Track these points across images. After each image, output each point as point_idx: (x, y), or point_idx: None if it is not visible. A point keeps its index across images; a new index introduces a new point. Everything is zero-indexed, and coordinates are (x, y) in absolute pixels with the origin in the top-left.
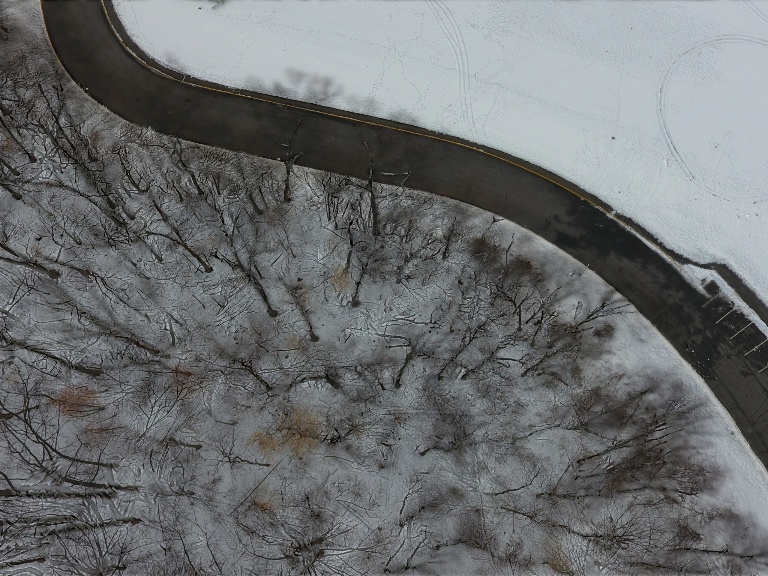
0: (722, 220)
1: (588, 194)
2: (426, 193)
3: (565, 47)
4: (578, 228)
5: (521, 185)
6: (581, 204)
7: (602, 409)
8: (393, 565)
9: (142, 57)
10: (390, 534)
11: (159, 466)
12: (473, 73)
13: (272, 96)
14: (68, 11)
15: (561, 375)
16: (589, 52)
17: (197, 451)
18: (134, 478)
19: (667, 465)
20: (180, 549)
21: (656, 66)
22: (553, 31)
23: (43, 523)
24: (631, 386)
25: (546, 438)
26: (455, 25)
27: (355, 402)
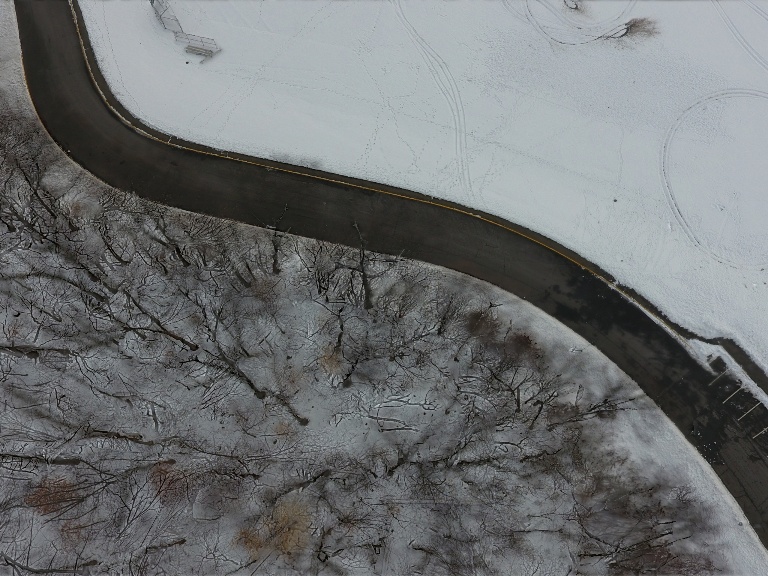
0: (729, 291)
1: (589, 263)
2: (421, 262)
3: (565, 103)
4: (579, 299)
5: (520, 253)
6: (582, 274)
7: (604, 506)
8: None
9: (126, 117)
10: None
11: (139, 572)
12: (470, 131)
13: (261, 159)
14: (50, 67)
15: (561, 460)
16: (590, 108)
17: (180, 546)
18: None
19: (672, 557)
20: None
21: (659, 123)
22: (553, 85)
23: None
24: (634, 471)
25: (546, 529)
26: (451, 80)
27: (346, 491)
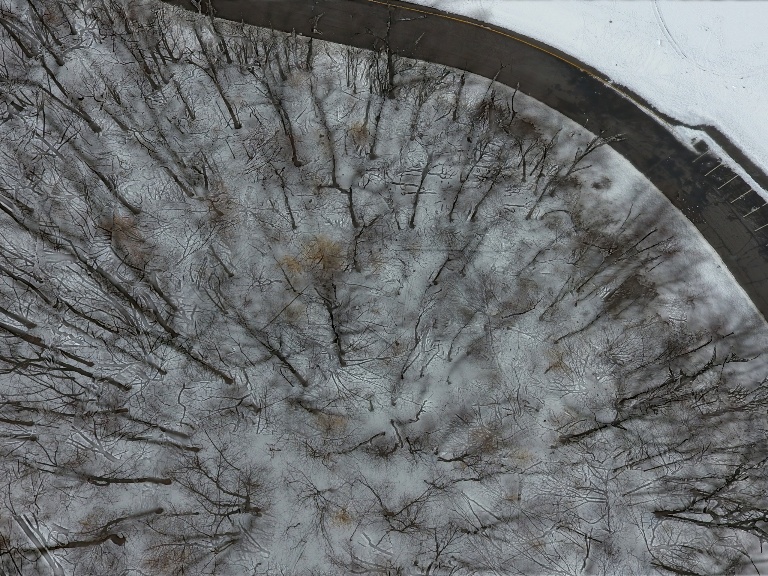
0: (711, 89)
1: (587, 66)
2: (437, 64)
3: None
4: (578, 96)
5: (525, 58)
6: (581, 75)
7: None
8: (409, 373)
9: None
10: (406, 348)
11: (198, 276)
12: None
13: None
14: None
15: (562, 219)
16: None
17: (229, 278)
18: (175, 289)
19: (659, 296)
20: (216, 357)
21: None
22: None
23: (95, 321)
24: (626, 230)
25: (548, 272)
26: None
27: (373, 239)
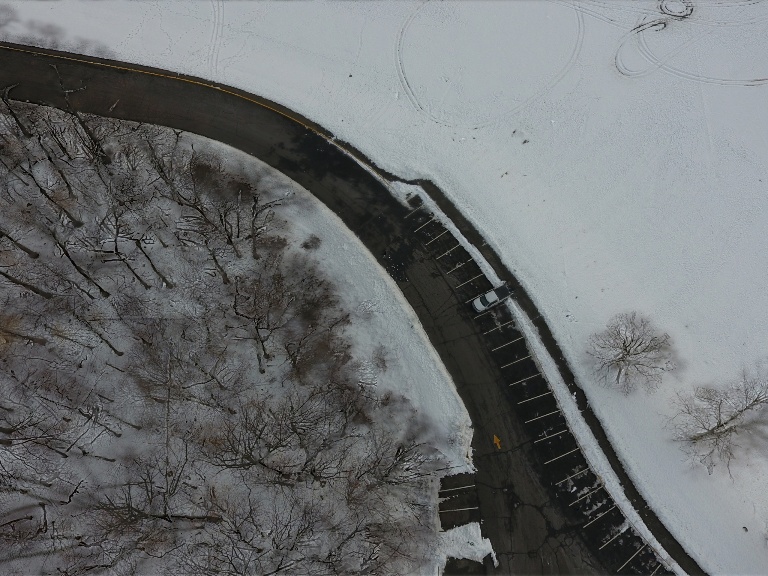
0: (434, 142)
1: (312, 123)
2: (161, 127)
3: None
4: (300, 153)
5: (252, 117)
6: (305, 132)
7: None
8: (73, 451)
9: None
10: (76, 424)
11: None
12: (227, 23)
13: (29, 46)
14: None
15: (262, 282)
16: (339, 2)
17: None
18: None
19: (353, 359)
20: None
21: (400, 12)
22: None
23: None
24: (330, 291)
25: (241, 338)
26: None
27: (63, 310)
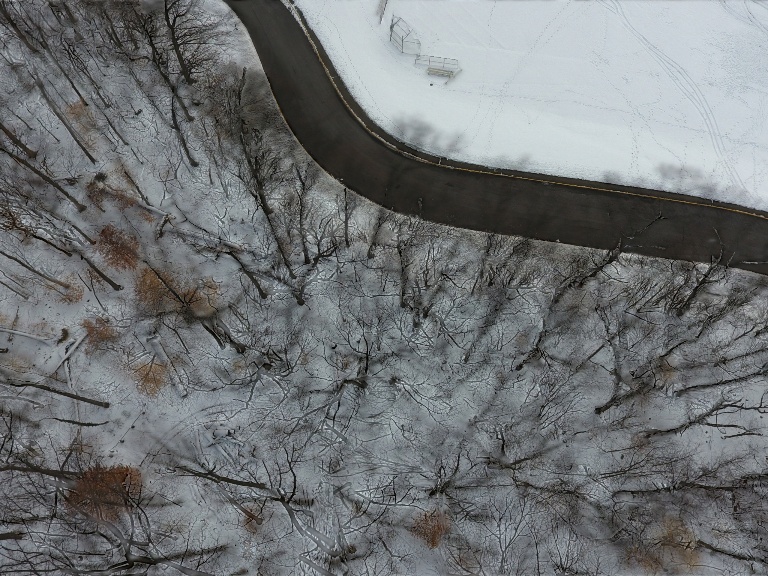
0: None
1: None
2: None
3: None
4: None
5: None
6: None
7: None
8: None
9: (391, 141)
10: None
11: None
12: (724, 133)
13: (535, 174)
14: (302, 98)
15: None
16: None
17: None
18: None
19: None
20: None
21: None
22: None
23: None
24: None
25: None
26: (693, 84)
27: (706, 502)
